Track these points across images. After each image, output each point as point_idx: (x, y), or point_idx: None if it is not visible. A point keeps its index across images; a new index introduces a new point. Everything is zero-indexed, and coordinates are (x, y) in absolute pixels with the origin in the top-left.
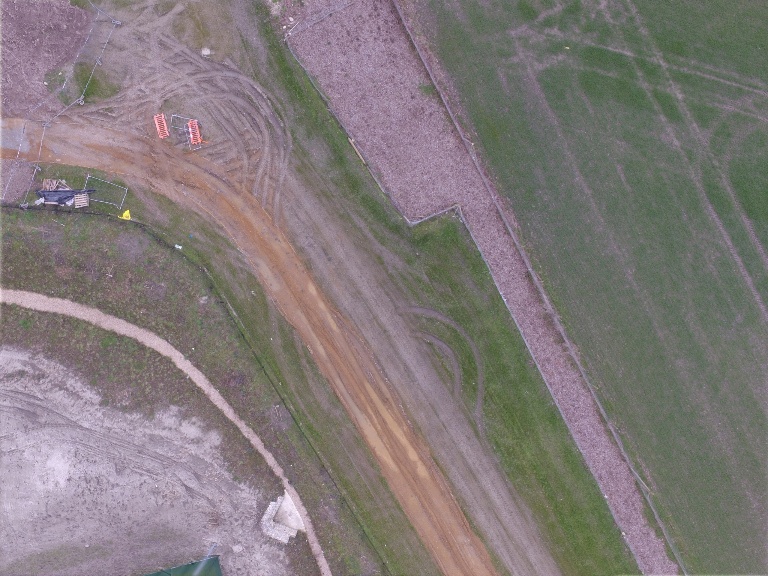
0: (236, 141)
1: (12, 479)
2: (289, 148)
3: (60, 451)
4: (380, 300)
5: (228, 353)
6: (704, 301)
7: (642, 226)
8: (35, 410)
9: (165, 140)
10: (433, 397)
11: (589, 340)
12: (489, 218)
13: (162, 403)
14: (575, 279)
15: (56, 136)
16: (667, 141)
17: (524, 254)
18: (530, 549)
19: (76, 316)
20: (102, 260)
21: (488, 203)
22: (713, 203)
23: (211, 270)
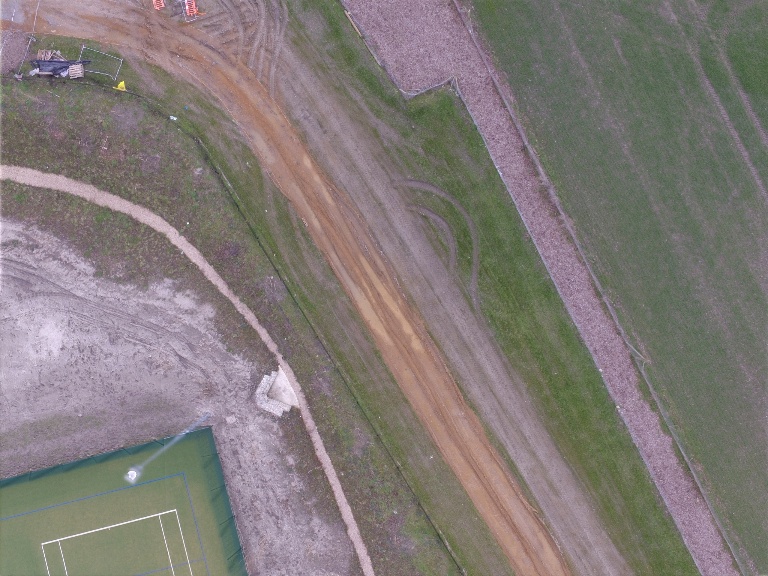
0: (232, 13)
1: (5, 348)
2: (285, 21)
3: (53, 320)
4: (375, 173)
5: (223, 224)
6: (700, 175)
7: (639, 100)
8: (28, 279)
9: (160, 12)
10: (428, 271)
11: (585, 214)
12: (485, 92)
13: (156, 276)
14: (571, 153)
15: (51, 7)
16: (664, 15)
17: (520, 127)
18: (524, 422)
19: (70, 192)
20: (97, 131)
21: (484, 76)
22: (710, 77)
23: (206, 142)
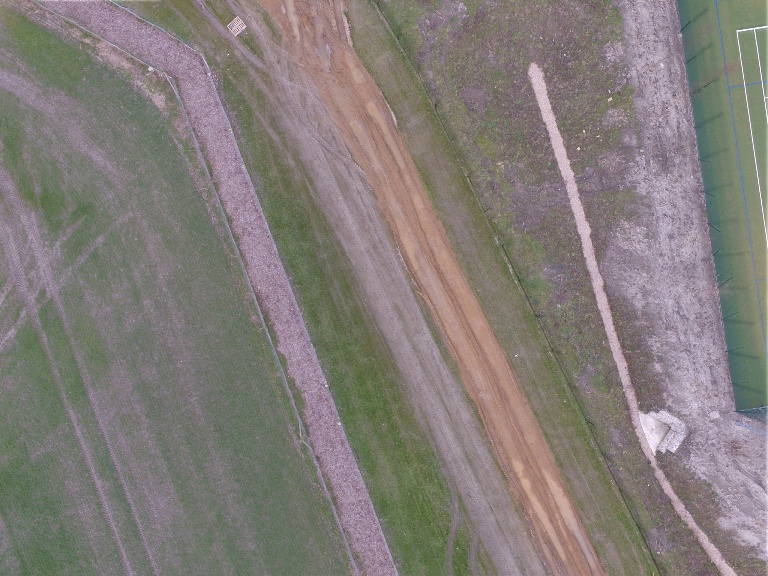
0: None
1: None
2: None
3: None
4: None
5: None
6: None
7: None
8: None
9: None
10: (499, 539)
11: None
12: None
13: None
14: None
15: None
16: None
17: None
18: (420, 379)
19: None
20: None
21: None
22: None
23: None
